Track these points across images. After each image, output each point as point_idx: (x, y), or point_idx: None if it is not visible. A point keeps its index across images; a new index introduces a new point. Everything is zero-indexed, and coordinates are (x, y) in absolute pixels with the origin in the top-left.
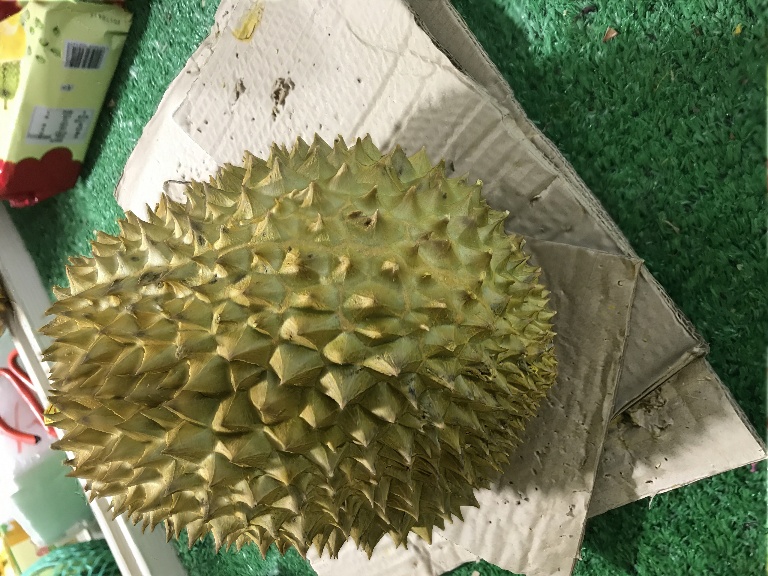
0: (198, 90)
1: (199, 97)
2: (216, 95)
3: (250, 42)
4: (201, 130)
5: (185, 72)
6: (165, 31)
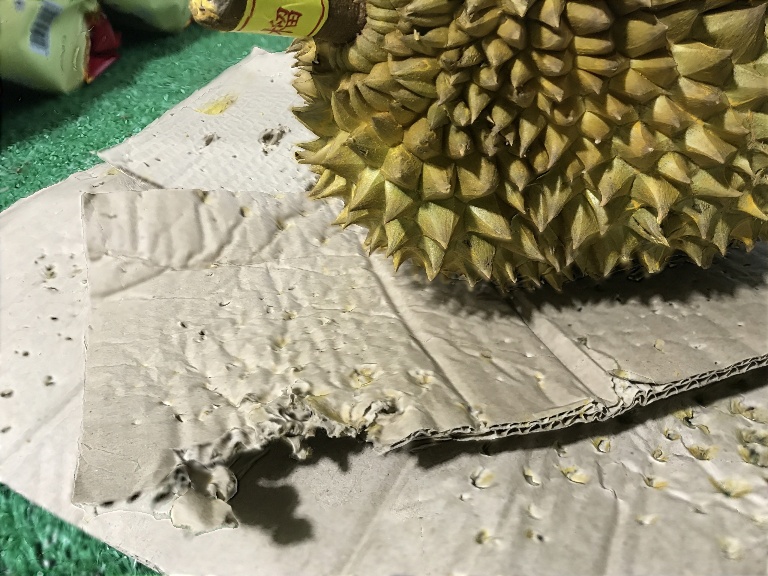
0: (145, 138)
1: (146, 142)
2: (174, 142)
3: (221, 114)
4: (149, 165)
5: (72, 176)
6: (6, 181)
